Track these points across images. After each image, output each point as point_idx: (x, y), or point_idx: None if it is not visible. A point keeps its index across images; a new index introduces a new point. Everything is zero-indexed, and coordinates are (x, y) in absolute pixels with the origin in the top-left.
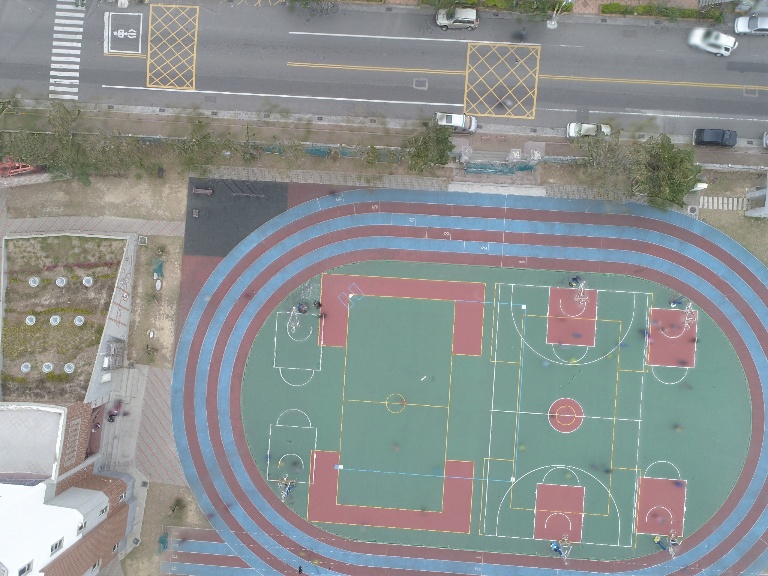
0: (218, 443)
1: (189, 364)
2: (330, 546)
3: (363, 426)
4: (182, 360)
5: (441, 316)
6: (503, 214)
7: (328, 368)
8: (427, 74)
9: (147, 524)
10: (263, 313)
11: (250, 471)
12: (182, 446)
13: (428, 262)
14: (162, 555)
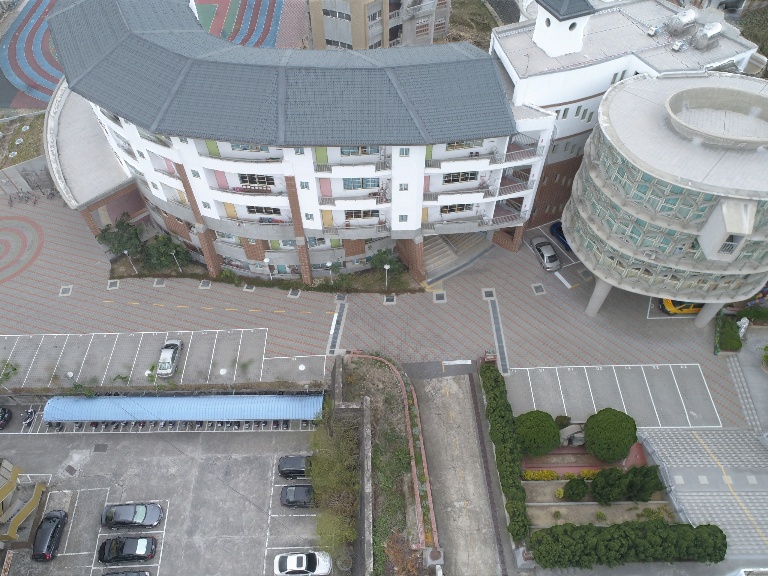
0: None
1: None
2: (234, 40)
3: None
4: None
5: None
6: None
7: None
8: None
9: None
10: None
11: None
12: None
13: None
14: None
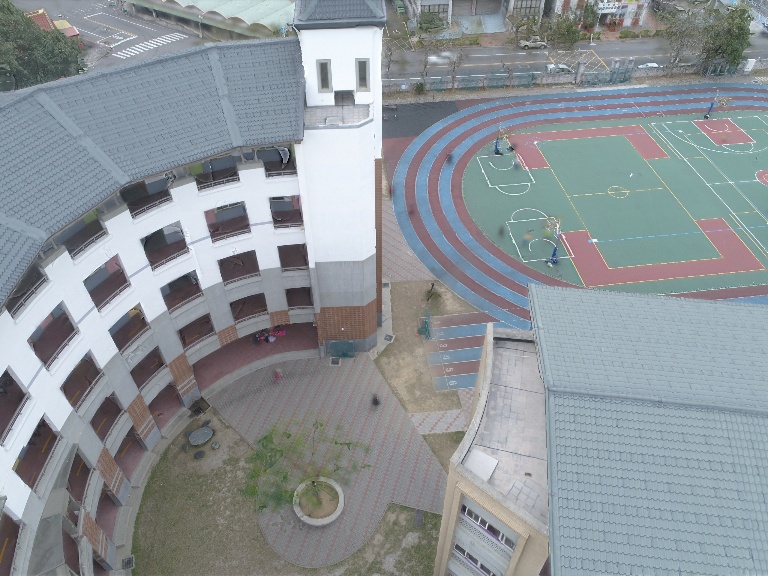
0: (457, 242)
1: (407, 195)
2: None
3: (598, 210)
4: (399, 193)
5: (618, 143)
6: (626, 96)
7: (541, 181)
8: (526, 63)
9: (398, 320)
10: (464, 159)
11: (501, 257)
12: (419, 249)
13: (587, 121)
14: (426, 347)
